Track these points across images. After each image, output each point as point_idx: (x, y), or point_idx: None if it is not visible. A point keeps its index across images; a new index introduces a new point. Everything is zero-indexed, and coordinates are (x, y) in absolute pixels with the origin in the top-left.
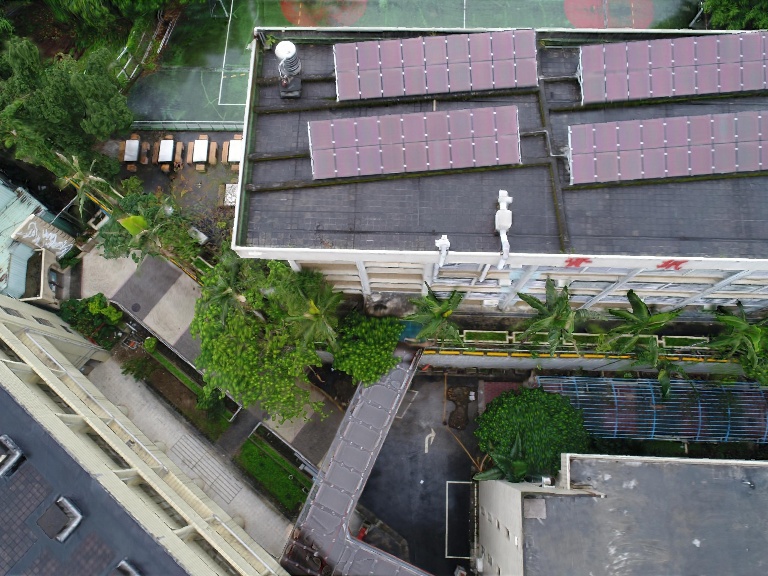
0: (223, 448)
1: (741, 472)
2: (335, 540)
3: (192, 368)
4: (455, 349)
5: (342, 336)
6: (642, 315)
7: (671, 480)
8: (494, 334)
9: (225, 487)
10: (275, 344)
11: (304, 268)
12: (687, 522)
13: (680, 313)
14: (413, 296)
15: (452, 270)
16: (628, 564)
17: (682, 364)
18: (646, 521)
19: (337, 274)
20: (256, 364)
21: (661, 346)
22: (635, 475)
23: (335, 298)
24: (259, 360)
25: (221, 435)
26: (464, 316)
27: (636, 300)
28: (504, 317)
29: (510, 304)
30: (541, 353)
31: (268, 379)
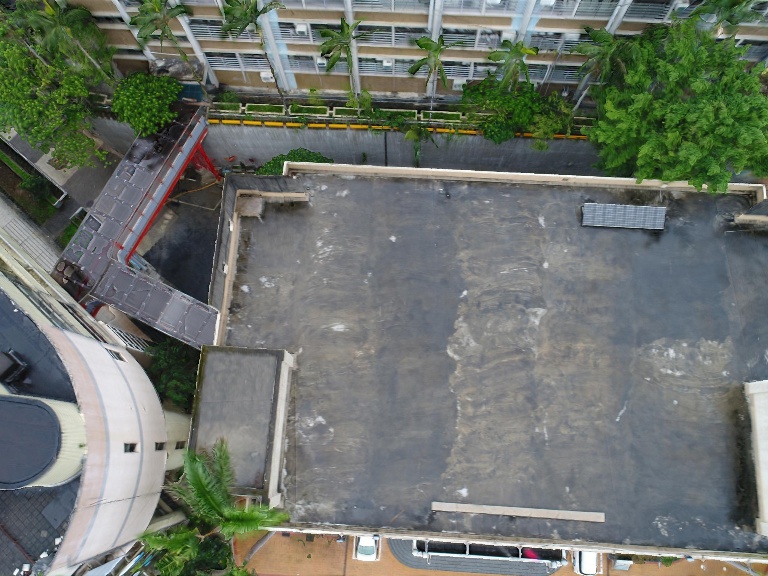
0: (48, 230)
1: (440, 185)
2: (101, 258)
3: (25, 161)
4: (236, 118)
5: (118, 84)
6: (344, 33)
7: (379, 190)
8: (272, 107)
9: (46, 262)
10: (46, 76)
11: (69, 5)
12: (387, 223)
13: (444, 97)
14: (193, 63)
15: (194, 5)
16: (331, 254)
17: (444, 142)
18: (352, 222)
19: (103, 16)
20: (30, 94)
21: (419, 119)
22: (348, 186)
23: (78, 12)
24: (34, 92)
25: (47, 219)
26: (252, 96)
27: (342, 23)
28: (287, 98)
29: (294, 87)
30: (312, 123)
31: (38, 104)
